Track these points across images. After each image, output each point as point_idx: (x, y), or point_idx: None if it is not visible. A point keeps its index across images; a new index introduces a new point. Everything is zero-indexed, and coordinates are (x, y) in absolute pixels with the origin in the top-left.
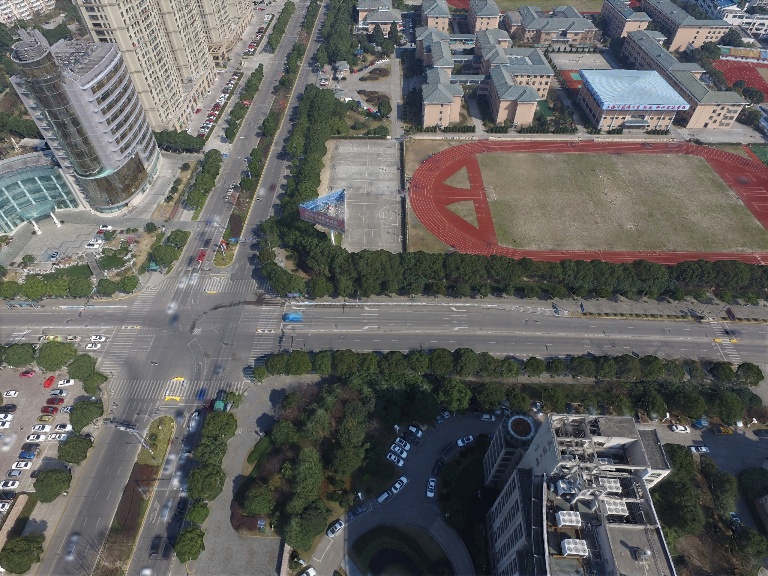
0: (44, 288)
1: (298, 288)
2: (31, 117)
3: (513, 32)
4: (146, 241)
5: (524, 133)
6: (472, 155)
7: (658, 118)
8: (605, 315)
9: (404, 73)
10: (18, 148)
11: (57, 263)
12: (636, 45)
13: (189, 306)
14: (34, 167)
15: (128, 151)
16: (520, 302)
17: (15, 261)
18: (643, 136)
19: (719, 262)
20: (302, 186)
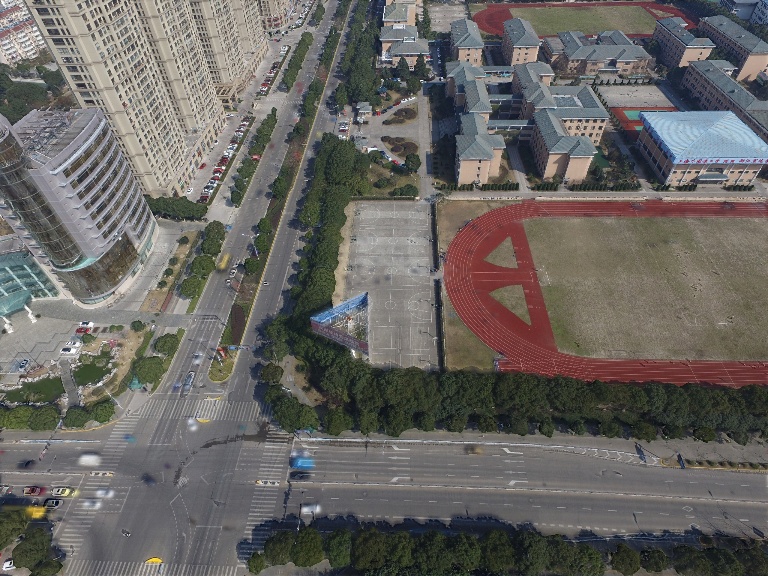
0: (1, 420)
1: (309, 424)
2: None
3: (554, 61)
4: (131, 343)
5: (577, 190)
6: (517, 221)
7: (740, 172)
8: (708, 464)
9: (433, 115)
10: (1, 217)
11: (25, 375)
12: (701, 77)
13: (175, 442)
14: (4, 256)
15: (113, 234)
16: (593, 441)
17: None
18: (721, 193)
19: None
20: (316, 274)
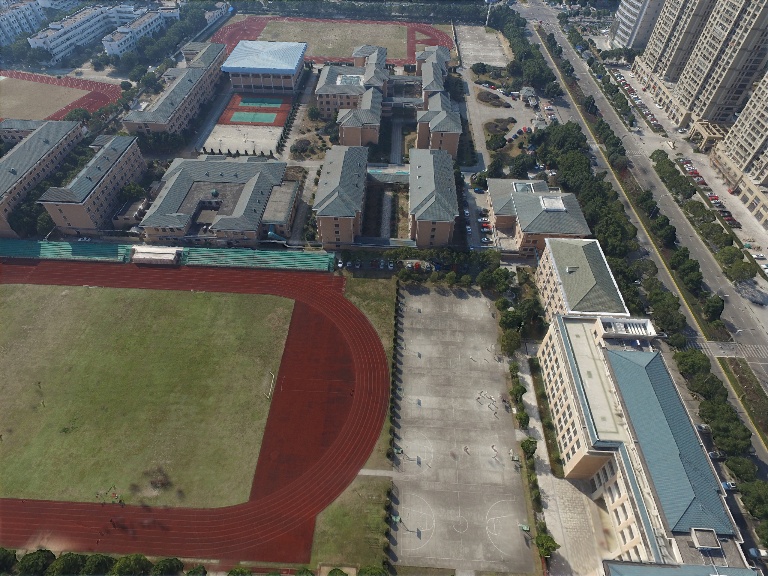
0: None
1: None
2: None
3: None
4: None
5: None
6: (410, 58)
7: None
8: None
9: None
10: None
11: None
12: None
13: None
14: None
15: None
16: None
17: None
18: None
19: (321, 1)
20: None
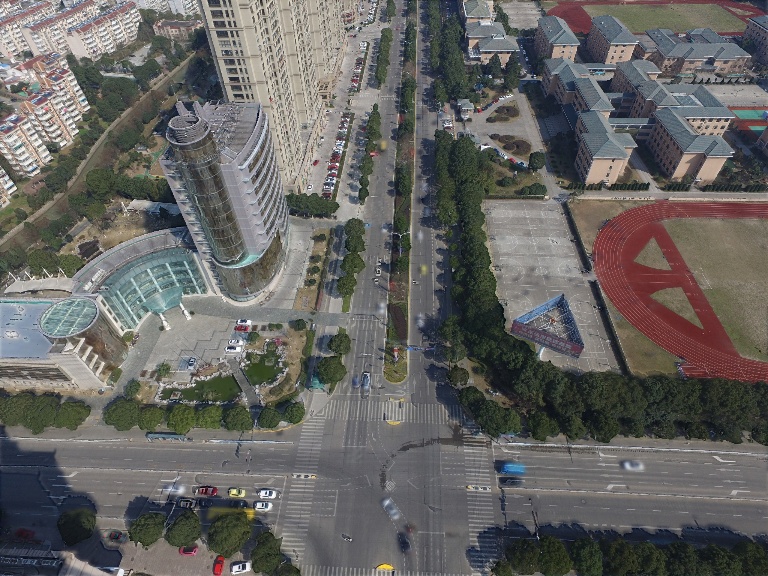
0: (194, 419)
1: (515, 428)
2: (134, 171)
3: (646, 59)
4: (295, 342)
5: (709, 191)
6: (656, 222)
7: None
8: None
9: (538, 112)
10: (127, 212)
11: (196, 373)
12: None
13: (370, 444)
14: (165, 251)
15: (272, 231)
16: None
17: (146, 369)
18: None
19: None
20: (480, 274)
